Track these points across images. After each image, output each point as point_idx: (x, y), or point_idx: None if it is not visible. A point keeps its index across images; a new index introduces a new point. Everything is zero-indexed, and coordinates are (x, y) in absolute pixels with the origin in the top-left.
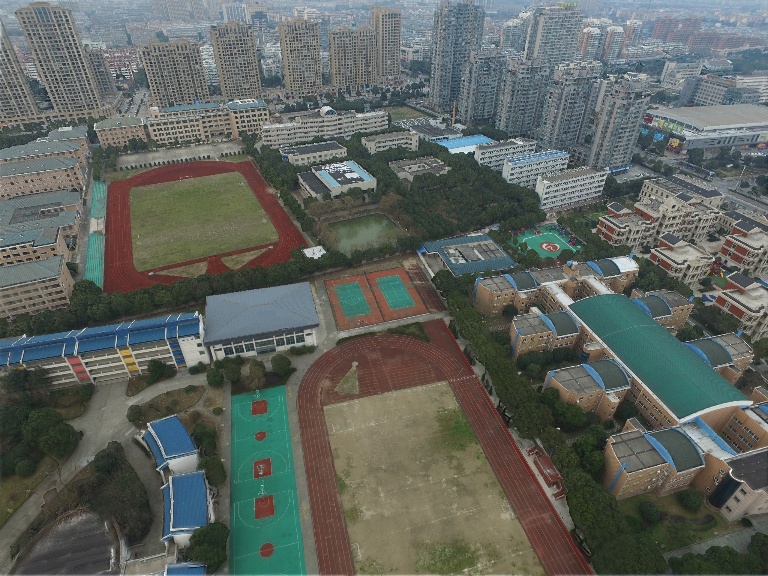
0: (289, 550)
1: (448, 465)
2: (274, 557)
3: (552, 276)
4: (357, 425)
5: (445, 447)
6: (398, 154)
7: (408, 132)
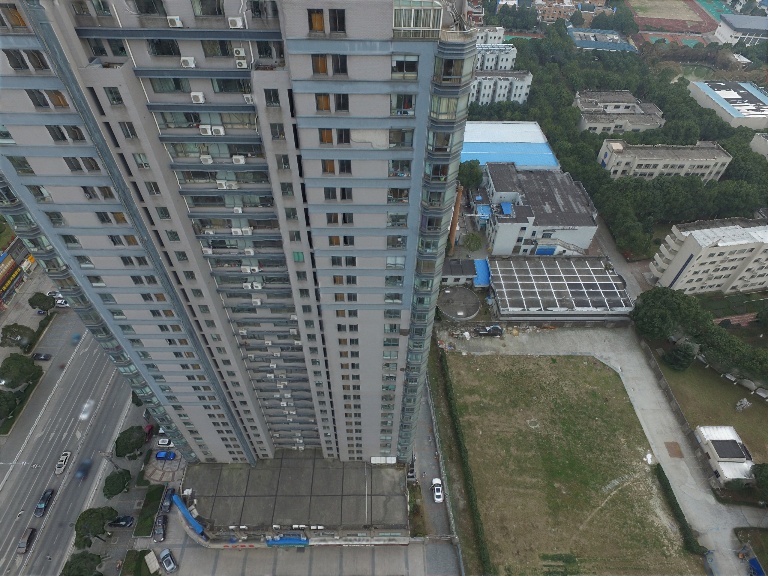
0: (707, 5)
1: (647, 5)
2: (712, 5)
3: (563, 6)
4: (686, 15)
5: (647, 7)
6: (649, 131)
7: (625, 155)
